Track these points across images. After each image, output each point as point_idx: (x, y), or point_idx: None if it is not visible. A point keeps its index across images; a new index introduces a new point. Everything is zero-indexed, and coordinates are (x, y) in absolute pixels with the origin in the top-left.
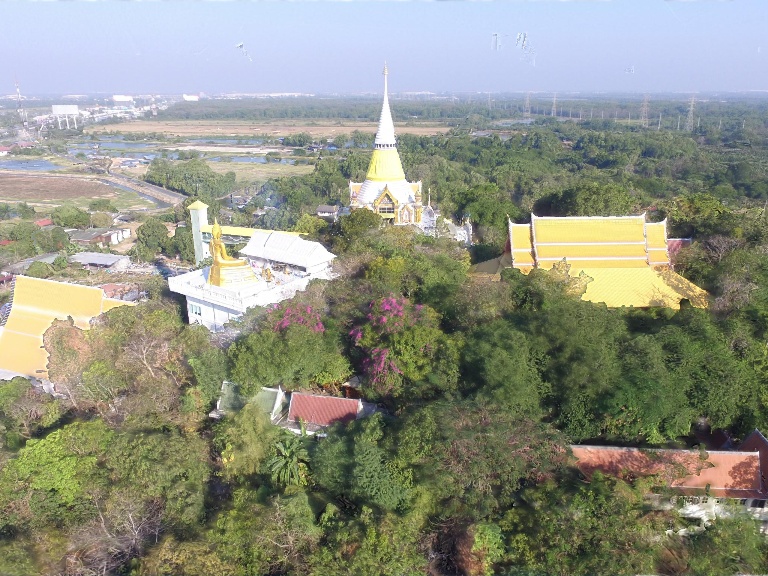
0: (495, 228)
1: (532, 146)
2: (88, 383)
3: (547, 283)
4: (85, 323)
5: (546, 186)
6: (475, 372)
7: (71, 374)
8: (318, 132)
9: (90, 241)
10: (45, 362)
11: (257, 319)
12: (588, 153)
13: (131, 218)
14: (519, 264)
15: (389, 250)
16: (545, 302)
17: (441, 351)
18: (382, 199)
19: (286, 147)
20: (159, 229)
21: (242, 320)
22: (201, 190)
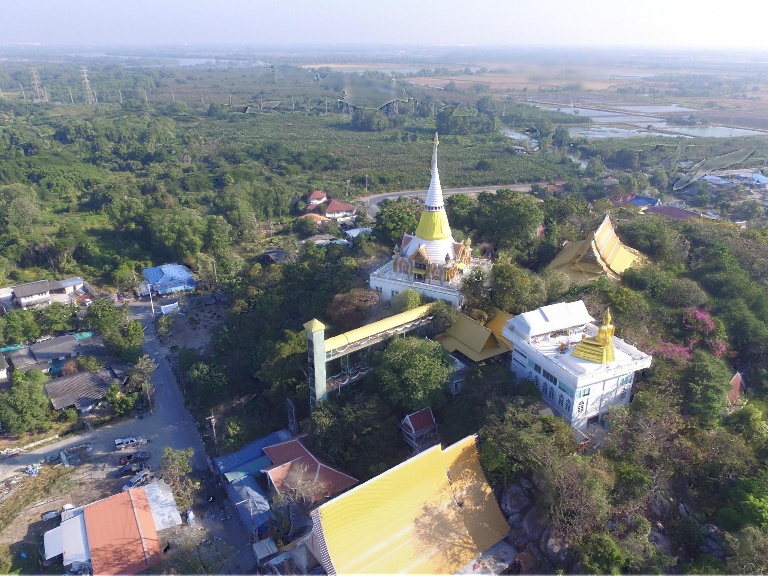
0: (479, 250)
1: (21, 146)
2: None
3: None
4: (436, 492)
5: None
6: None
7: None
8: None
9: None
10: (427, 564)
11: None
12: (101, 147)
13: None
14: None
15: (593, 287)
16: None
17: None
18: None
19: None
20: None
21: (657, 371)
22: None
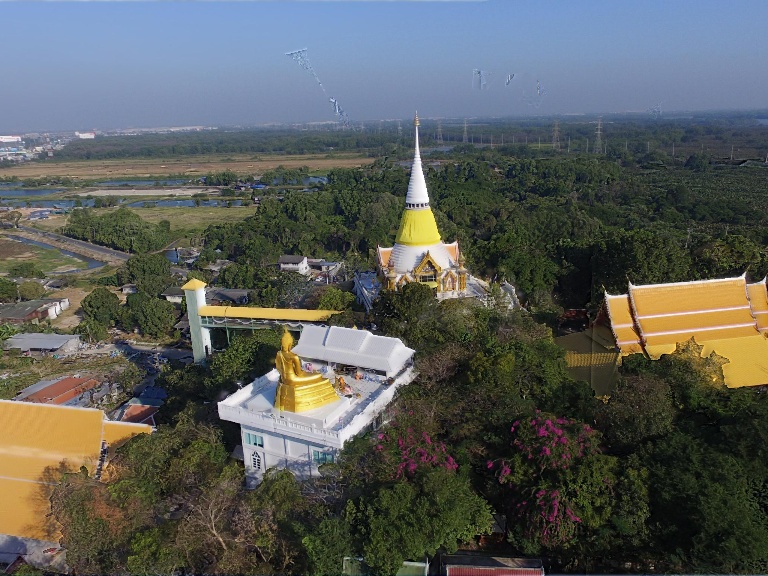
0: (541, 288)
1: (468, 176)
2: (137, 572)
3: (690, 373)
4: (80, 456)
5: (517, 222)
6: (671, 510)
7: (99, 552)
8: (240, 169)
9: (24, 319)
10: (27, 513)
11: (364, 458)
12: (524, 181)
13: (64, 284)
14: (623, 343)
15: (482, 340)
16: (693, 396)
17: (622, 485)
18: (423, 267)
19: (210, 187)
20: (109, 299)
21: (342, 460)
22: (137, 244)
